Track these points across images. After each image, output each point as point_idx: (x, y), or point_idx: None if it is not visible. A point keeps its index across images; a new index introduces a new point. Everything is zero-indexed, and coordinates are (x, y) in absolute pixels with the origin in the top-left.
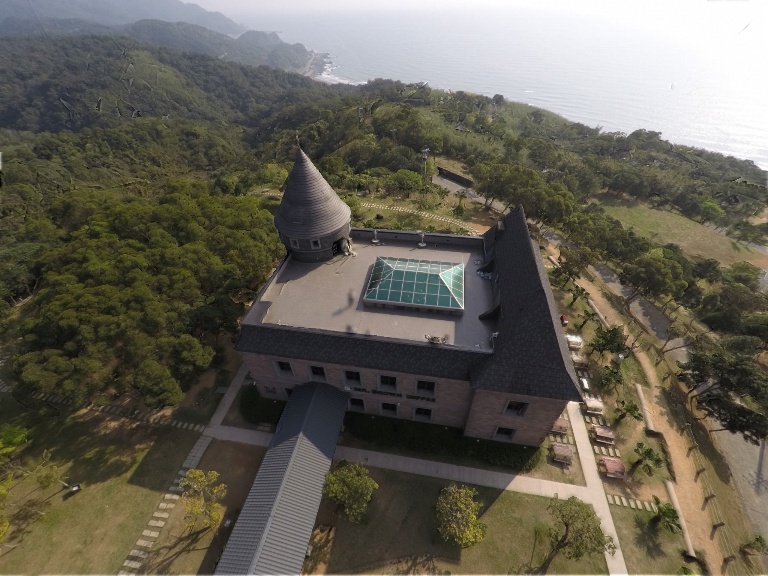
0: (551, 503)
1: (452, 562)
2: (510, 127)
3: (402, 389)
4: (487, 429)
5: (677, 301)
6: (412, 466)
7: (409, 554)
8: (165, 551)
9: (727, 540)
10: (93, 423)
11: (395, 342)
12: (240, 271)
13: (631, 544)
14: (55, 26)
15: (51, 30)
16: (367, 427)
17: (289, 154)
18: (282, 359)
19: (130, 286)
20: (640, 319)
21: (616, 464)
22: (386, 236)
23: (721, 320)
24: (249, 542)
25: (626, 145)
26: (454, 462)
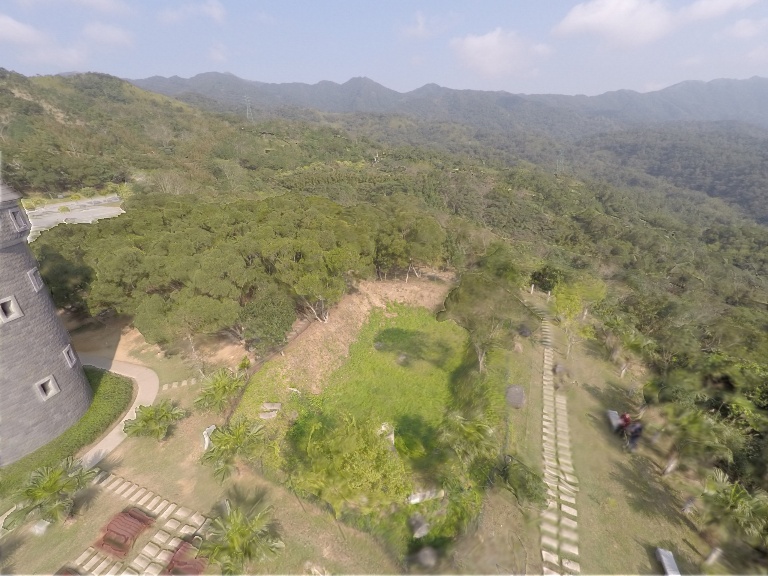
0: None
1: None
2: None
3: None
4: None
5: None
6: None
7: None
8: None
9: None
10: None
11: None
12: None
13: None
14: None
15: None
16: None
17: None
18: None
19: None
20: None
21: None
22: None
23: None
24: None
25: None
26: None
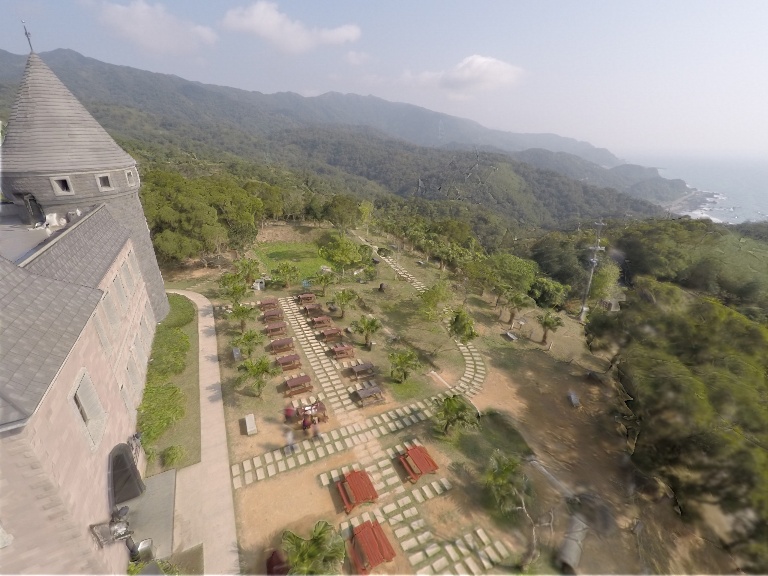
0: None
1: None
2: None
3: None
4: None
5: None
6: None
7: None
8: None
9: None
10: None
11: None
12: None
13: None
14: (446, 136)
15: (443, 138)
16: None
17: None
18: None
19: None
20: None
21: None
22: None
23: None
24: None
25: None
26: None
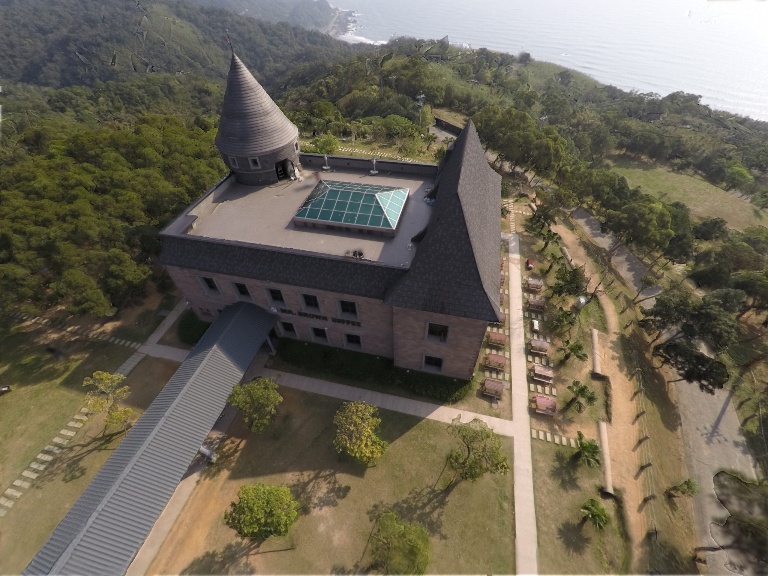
0: (452, 423)
1: (354, 479)
2: (524, 81)
3: (326, 311)
4: (415, 358)
5: (665, 255)
6: (336, 391)
7: (313, 468)
8: (78, 448)
9: (651, 480)
10: (34, 334)
11: (310, 255)
12: (189, 197)
13: (545, 476)
14: None
15: None
16: (298, 352)
17: None
18: (205, 274)
19: (72, 203)
20: (622, 274)
21: (548, 401)
22: (338, 163)
23: (709, 275)
24: (139, 438)
25: (657, 108)
26: (379, 390)
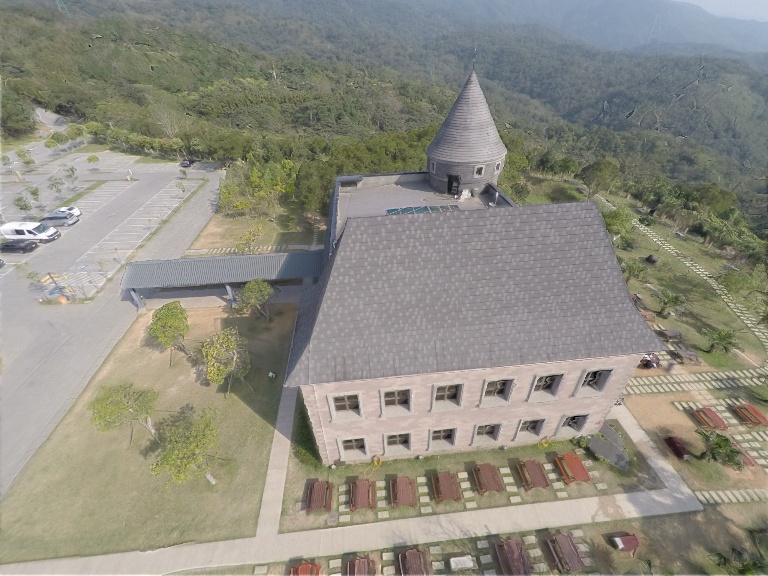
0: None
1: (215, 387)
2: None
3: None
4: None
5: None
6: None
7: None
8: None
9: None
10: None
11: (331, 228)
12: None
13: None
14: (659, 40)
15: (652, 43)
16: None
17: (767, 211)
18: None
19: None
20: None
21: None
22: None
23: None
24: None
25: None
26: None
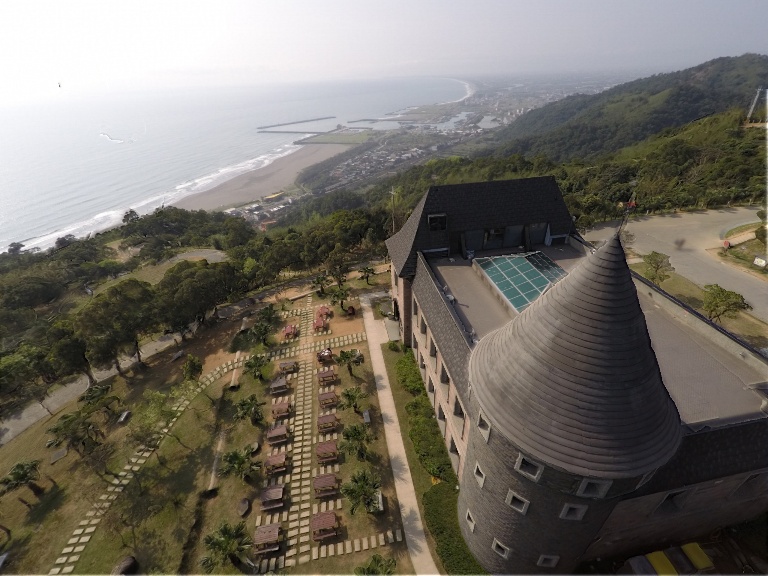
0: None
1: None
2: None
3: None
4: None
5: None
6: None
7: None
8: None
9: None
10: None
11: None
12: None
13: None
14: None
15: None
16: None
17: None
18: None
19: None
20: None
21: None
22: None
23: None
24: None
25: None
26: None
